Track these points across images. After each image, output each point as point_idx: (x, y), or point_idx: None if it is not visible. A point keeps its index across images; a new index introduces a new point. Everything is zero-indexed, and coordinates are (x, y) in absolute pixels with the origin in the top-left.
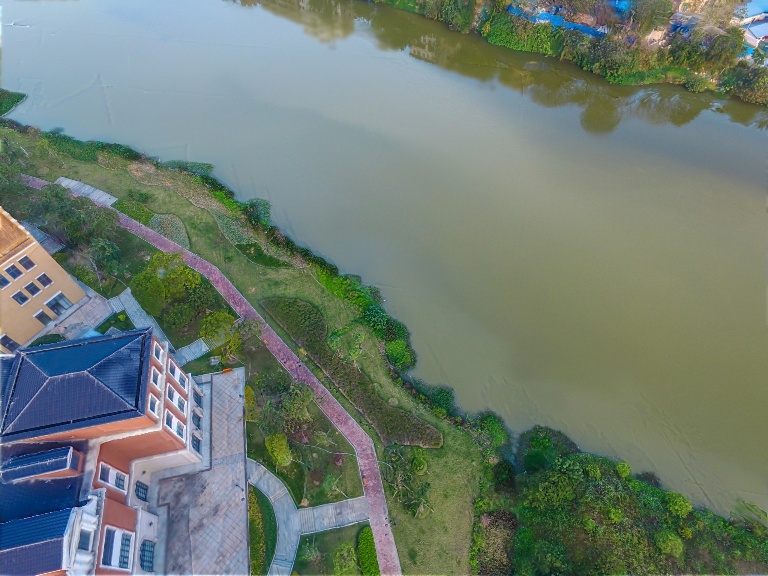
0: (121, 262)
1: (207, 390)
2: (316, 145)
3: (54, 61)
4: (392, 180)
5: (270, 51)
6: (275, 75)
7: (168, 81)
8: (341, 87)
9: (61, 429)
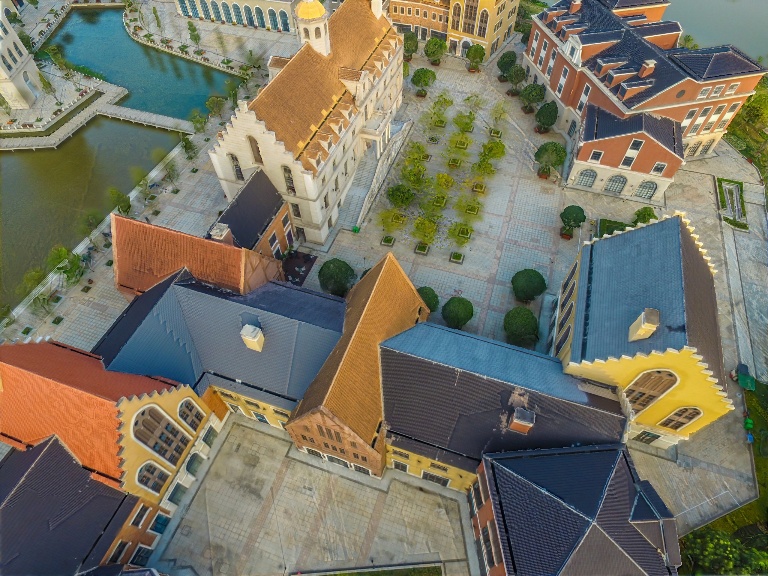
0: None
1: None
2: None
3: None
4: None
5: None
6: None
7: None
8: None
9: (638, 6)
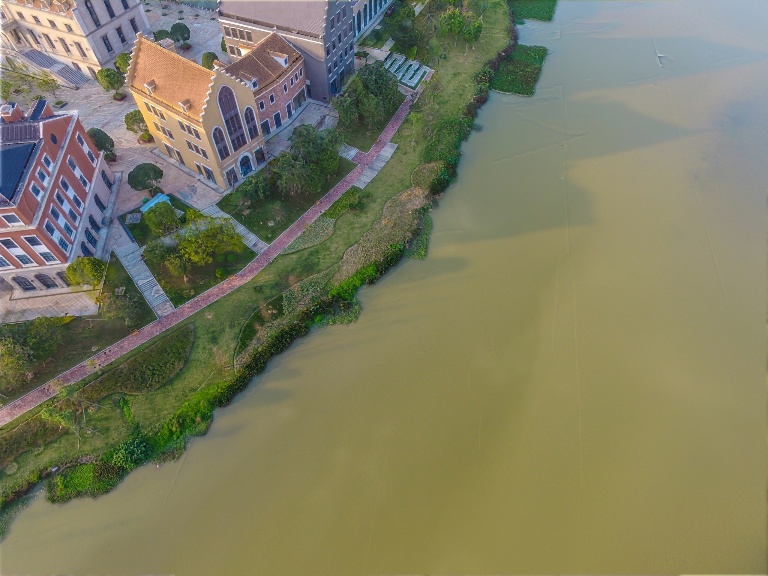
0: (263, 205)
1: (86, 288)
2: (472, 373)
3: (600, 98)
4: (390, 491)
5: (713, 294)
6: (643, 307)
7: (589, 192)
8: (640, 409)
9: None
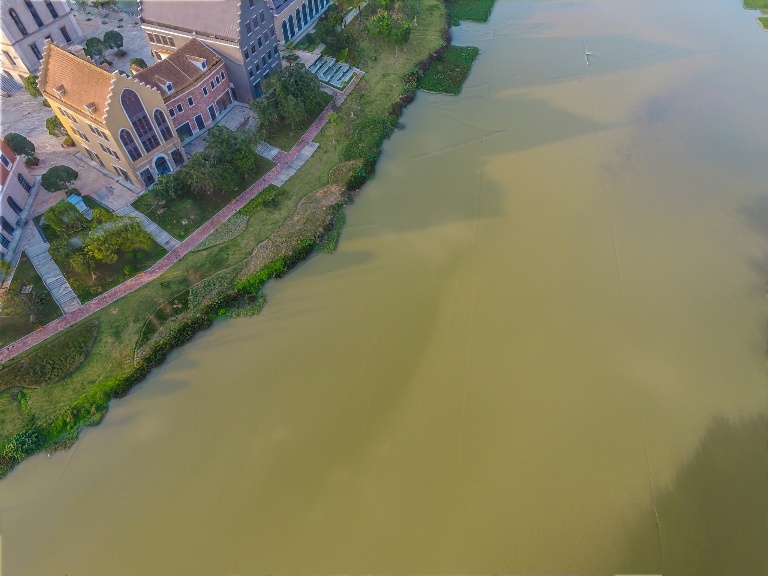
0: (177, 204)
1: None
2: (366, 360)
3: (524, 95)
4: (271, 474)
5: (609, 281)
6: (540, 294)
7: (502, 185)
8: (524, 390)
9: None
